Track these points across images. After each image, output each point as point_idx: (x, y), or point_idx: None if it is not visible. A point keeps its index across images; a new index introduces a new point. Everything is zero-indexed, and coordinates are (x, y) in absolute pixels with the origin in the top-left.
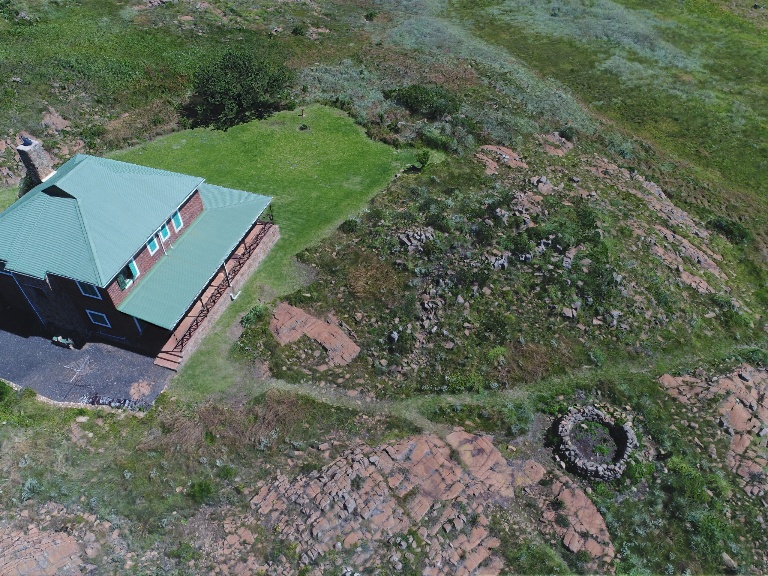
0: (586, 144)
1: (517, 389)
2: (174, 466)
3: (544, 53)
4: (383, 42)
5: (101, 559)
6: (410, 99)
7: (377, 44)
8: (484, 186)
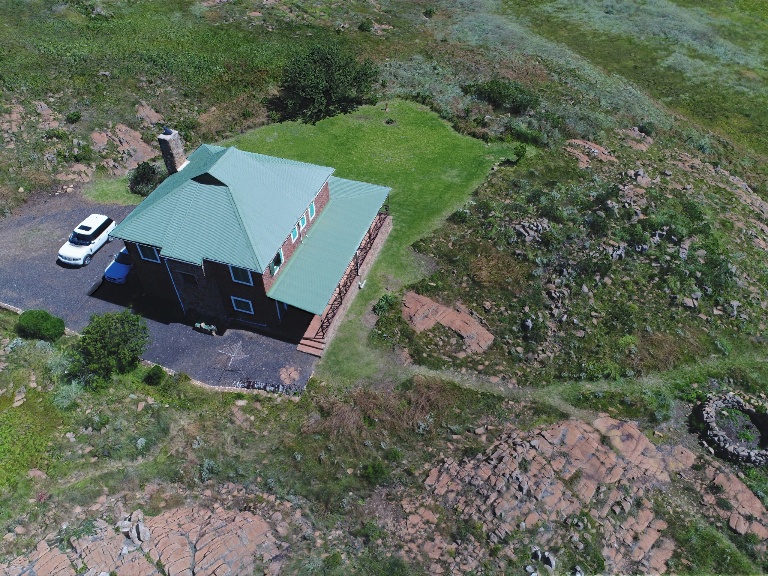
0: (665, 139)
1: (651, 377)
2: (340, 449)
3: (605, 50)
4: (447, 38)
5: (291, 537)
6: (493, 94)
7: (442, 40)
8: (582, 179)
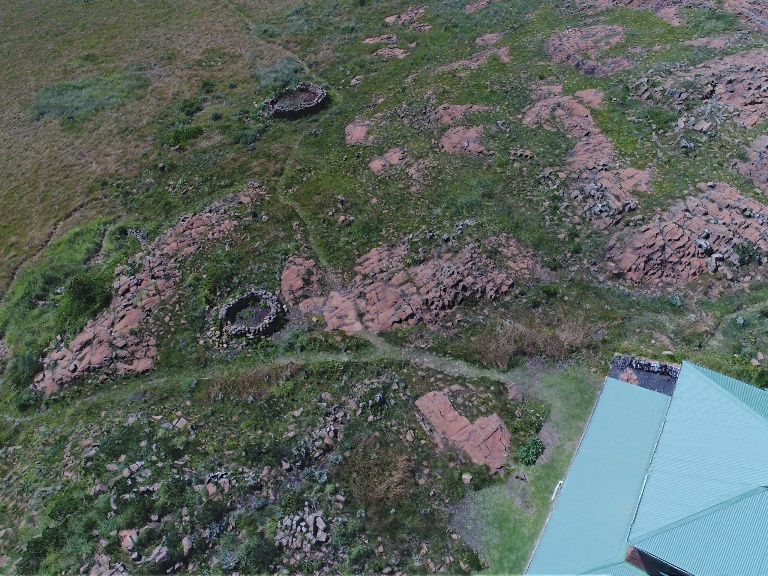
0: None
1: None
2: None
3: None
4: None
5: None
6: None
7: None
8: None
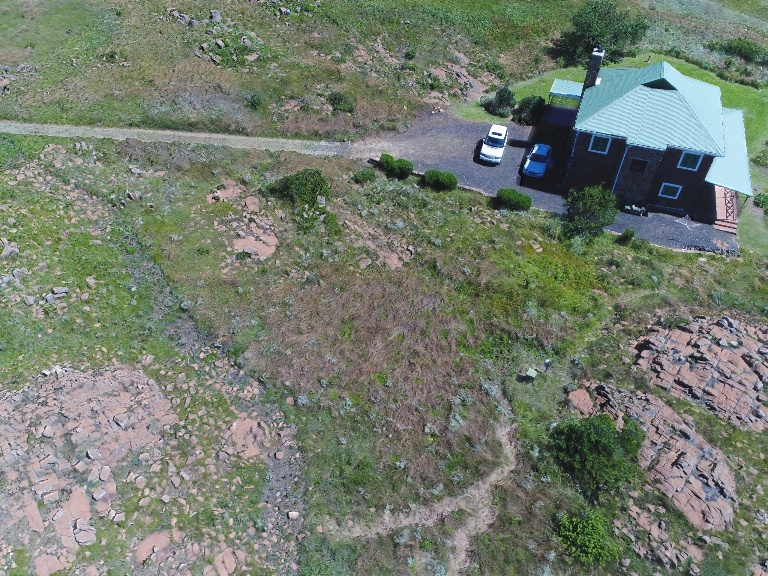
0: None
1: None
2: None
3: None
4: None
5: None
6: (745, 49)
7: (650, 9)
8: None
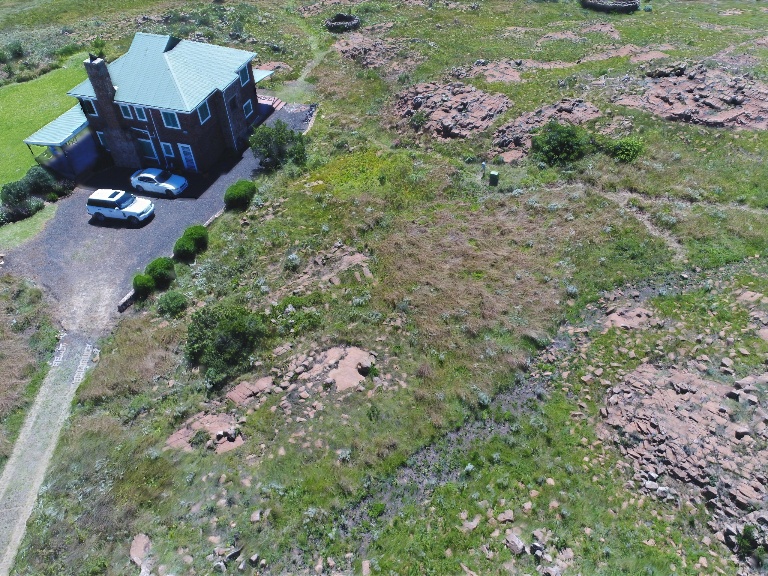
0: None
1: None
2: None
3: None
4: None
5: None
6: None
7: None
8: None
